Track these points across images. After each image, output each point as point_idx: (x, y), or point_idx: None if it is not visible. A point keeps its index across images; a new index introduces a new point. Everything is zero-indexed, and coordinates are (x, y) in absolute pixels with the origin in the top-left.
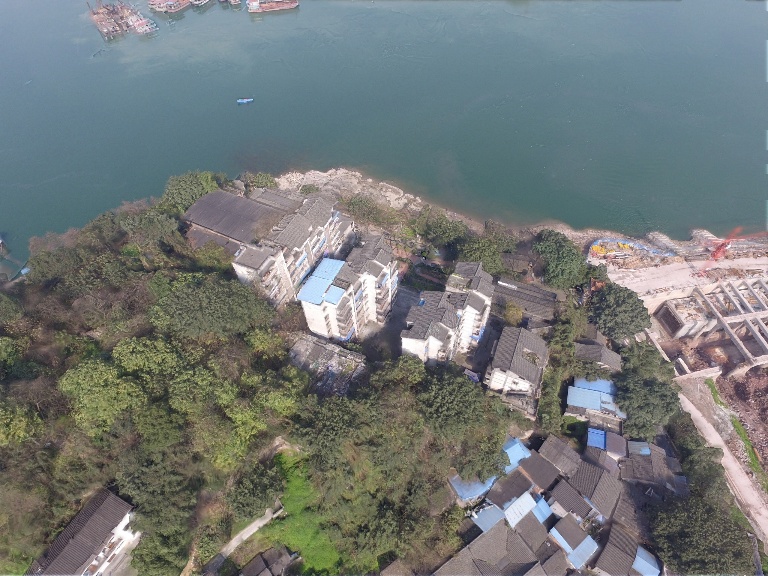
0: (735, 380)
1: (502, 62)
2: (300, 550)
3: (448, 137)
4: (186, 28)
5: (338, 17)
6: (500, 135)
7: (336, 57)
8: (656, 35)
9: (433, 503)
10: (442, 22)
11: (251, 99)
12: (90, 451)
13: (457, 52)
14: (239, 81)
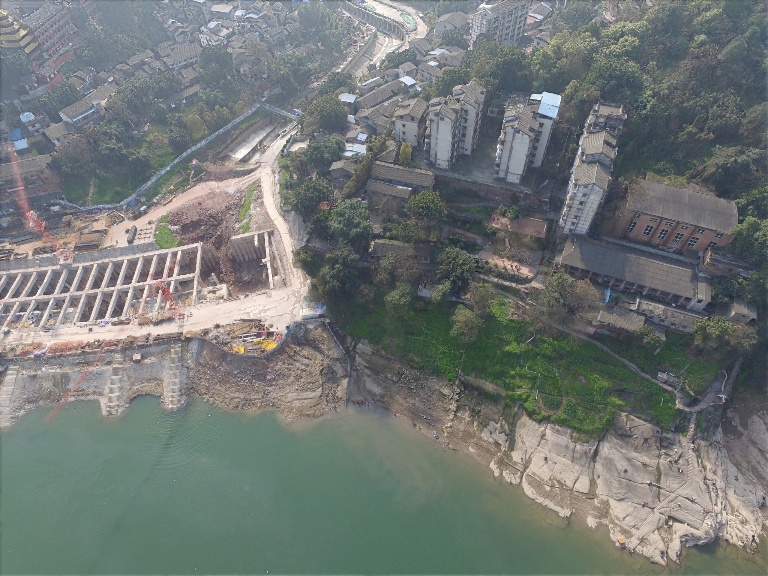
0: None
1: None
2: None
3: None
4: None
5: None
6: None
7: None
8: None
9: None
10: None
11: None
12: None
13: None
14: None
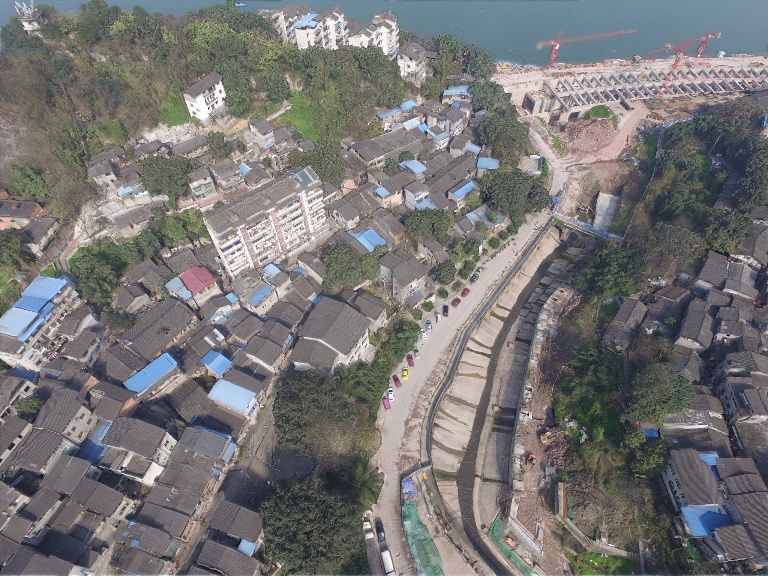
0: (561, 125)
1: None
2: (300, 129)
3: None
4: None
5: None
6: (431, 19)
7: None
8: None
9: (366, 114)
10: None
11: (245, 4)
12: (203, 53)
13: None
14: None
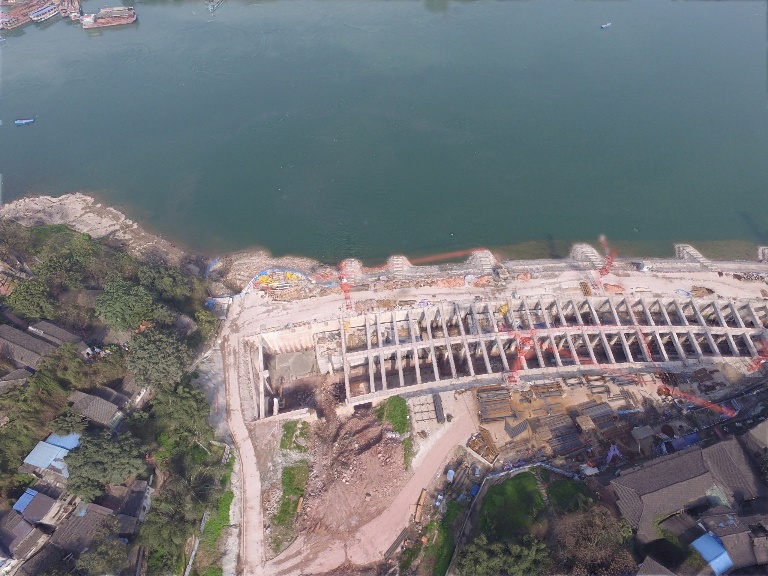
0: (340, 420)
1: (302, 78)
2: None
3: (203, 158)
4: (18, 45)
5: (171, 32)
6: (256, 155)
7: (145, 74)
8: (477, 47)
9: None
10: (264, 36)
11: (31, 120)
12: None
13: (258, 68)
14: (30, 101)
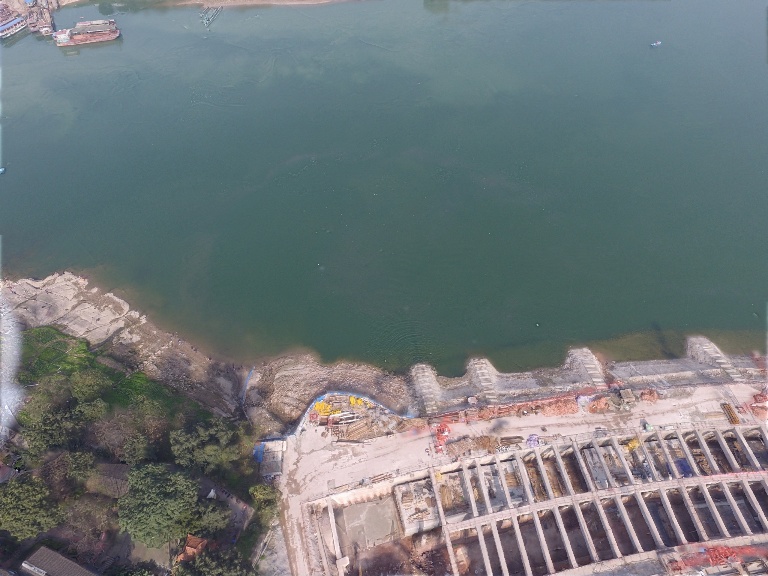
0: None
1: (324, 111)
2: None
3: (219, 221)
4: None
5: (162, 50)
6: (283, 216)
7: (135, 105)
8: (516, 69)
9: None
10: (272, 58)
11: (1, 169)
12: None
13: (271, 99)
14: None
